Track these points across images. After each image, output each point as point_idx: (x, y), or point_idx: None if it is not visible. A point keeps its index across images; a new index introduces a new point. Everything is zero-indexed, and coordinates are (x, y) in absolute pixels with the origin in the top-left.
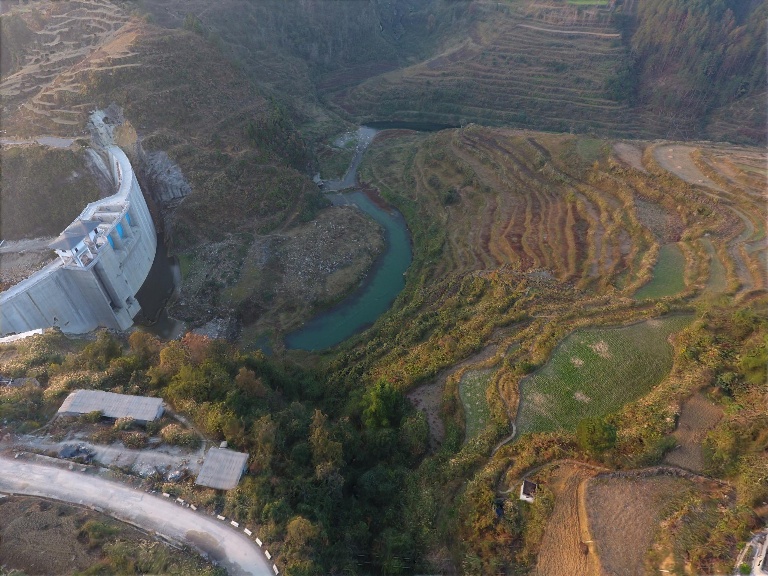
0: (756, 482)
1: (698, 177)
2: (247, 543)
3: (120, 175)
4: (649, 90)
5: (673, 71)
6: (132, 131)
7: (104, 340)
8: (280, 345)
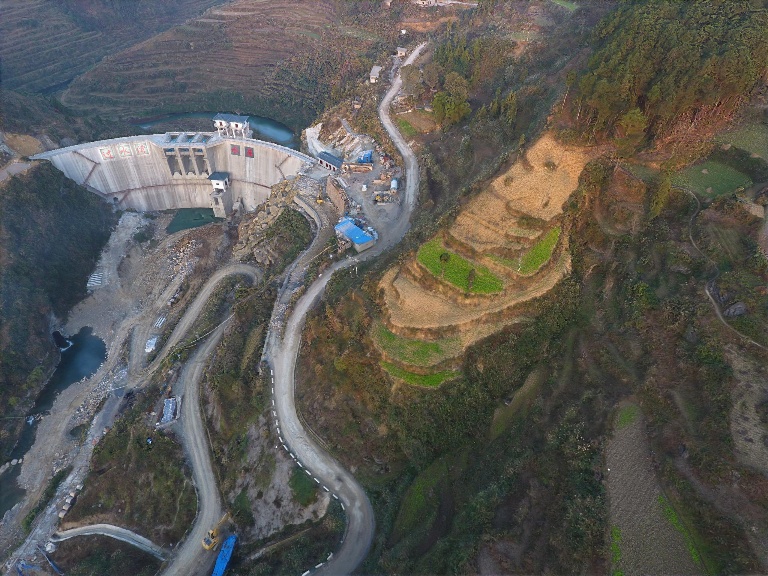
0: (407, 5)
1: (246, 13)
2: (421, 45)
3: (89, 158)
4: (95, 18)
5: (90, 3)
6: (23, 138)
7: (339, 84)
8: (287, 141)
